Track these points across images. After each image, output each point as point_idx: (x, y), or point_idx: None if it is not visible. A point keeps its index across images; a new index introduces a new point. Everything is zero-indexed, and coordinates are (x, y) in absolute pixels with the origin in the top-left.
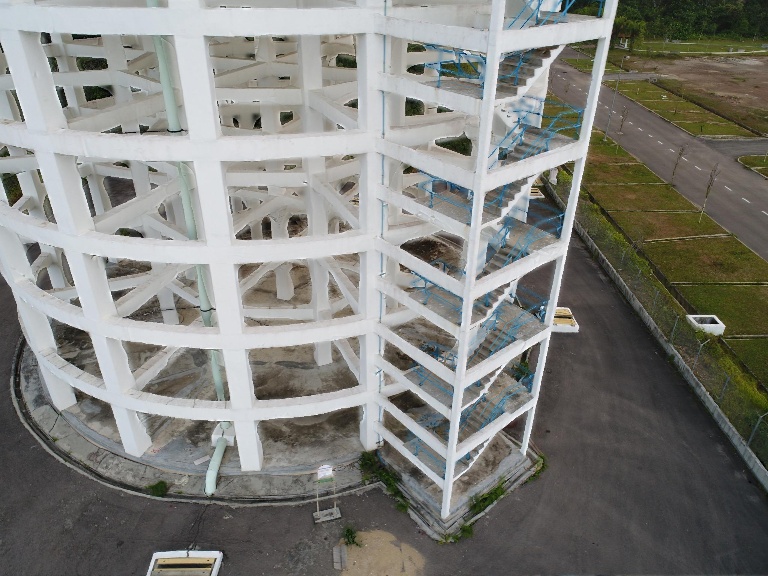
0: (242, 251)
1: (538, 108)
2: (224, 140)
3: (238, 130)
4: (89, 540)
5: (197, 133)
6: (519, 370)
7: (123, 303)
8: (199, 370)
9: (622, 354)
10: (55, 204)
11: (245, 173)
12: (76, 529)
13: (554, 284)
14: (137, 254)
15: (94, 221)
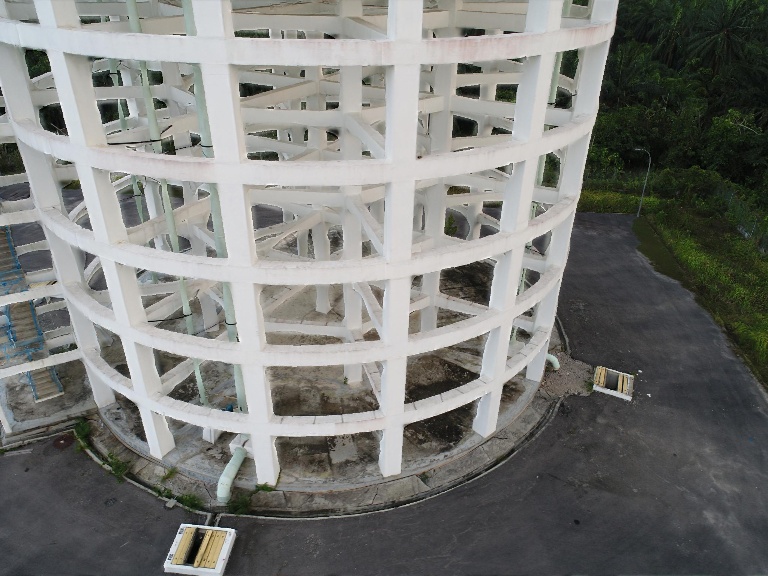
0: None
1: None
2: None
3: None
4: None
5: None
6: None
7: None
8: None
9: None
10: None
11: None
12: None
13: None
14: None
15: None
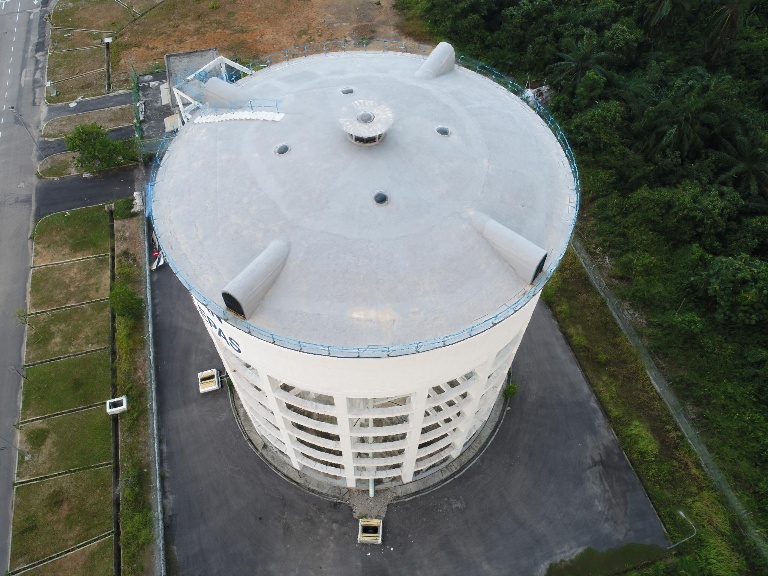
0: None
1: None
2: None
3: None
4: None
5: None
6: None
7: None
8: None
9: (180, 362)
10: None
11: None
12: None
13: None
14: None
15: None
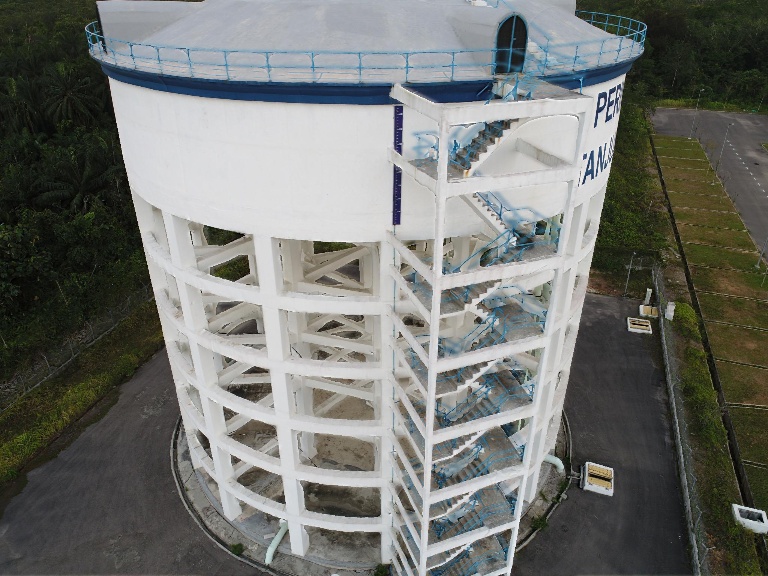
0: (296, 423)
1: (557, 331)
2: (288, 362)
3: (349, 281)
4: (187, 574)
5: (272, 356)
6: (535, 523)
7: (233, 423)
8: None
9: (644, 530)
10: (196, 367)
11: (331, 338)
12: (182, 563)
13: (519, 492)
14: (236, 409)
15: (220, 375)
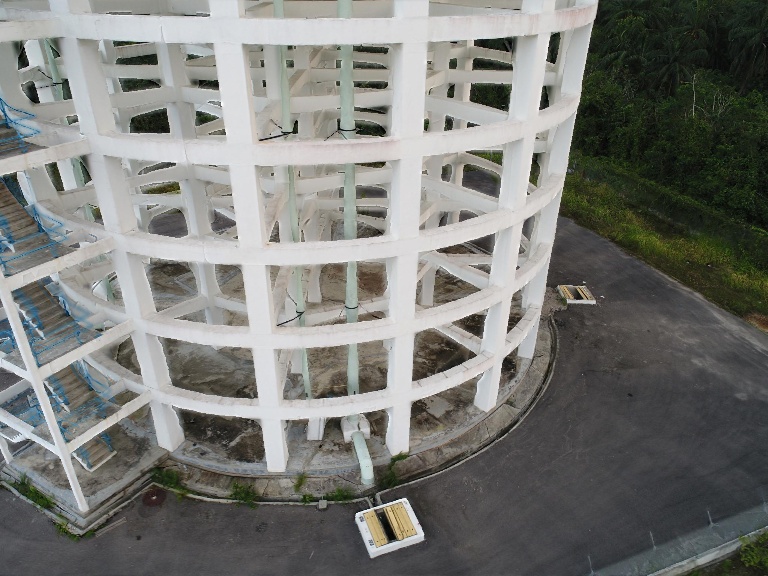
0: None
1: None
2: None
3: None
4: None
5: None
6: None
7: None
8: (193, 293)
9: None
10: None
11: None
12: None
13: None
14: None
15: None
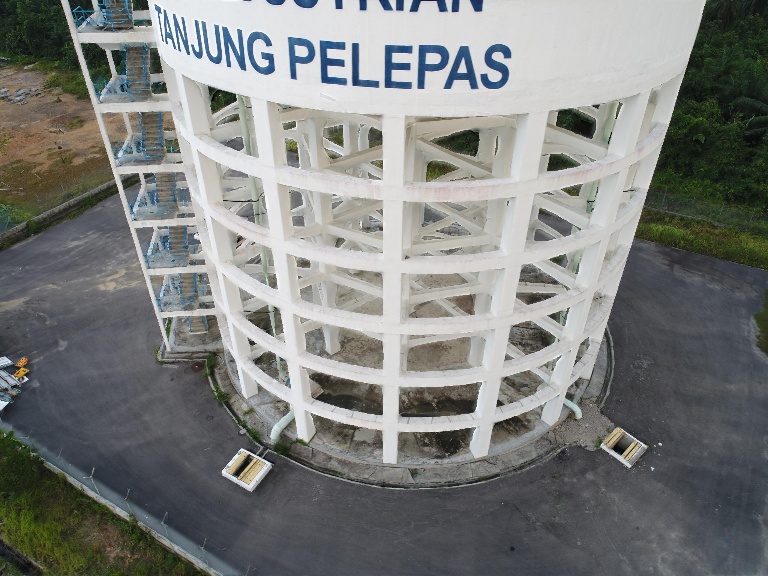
0: None
1: None
2: None
3: None
4: None
5: None
6: None
7: None
8: None
9: (172, 485)
10: None
11: None
12: None
13: None
14: None
15: None
